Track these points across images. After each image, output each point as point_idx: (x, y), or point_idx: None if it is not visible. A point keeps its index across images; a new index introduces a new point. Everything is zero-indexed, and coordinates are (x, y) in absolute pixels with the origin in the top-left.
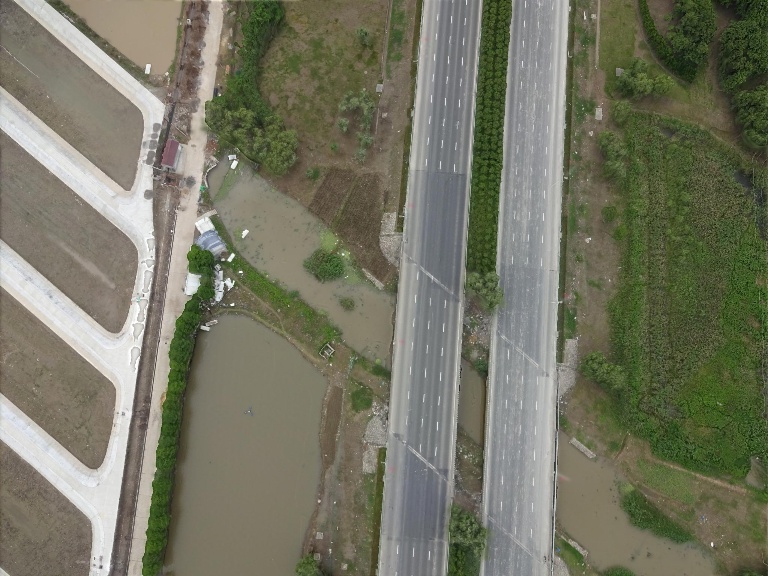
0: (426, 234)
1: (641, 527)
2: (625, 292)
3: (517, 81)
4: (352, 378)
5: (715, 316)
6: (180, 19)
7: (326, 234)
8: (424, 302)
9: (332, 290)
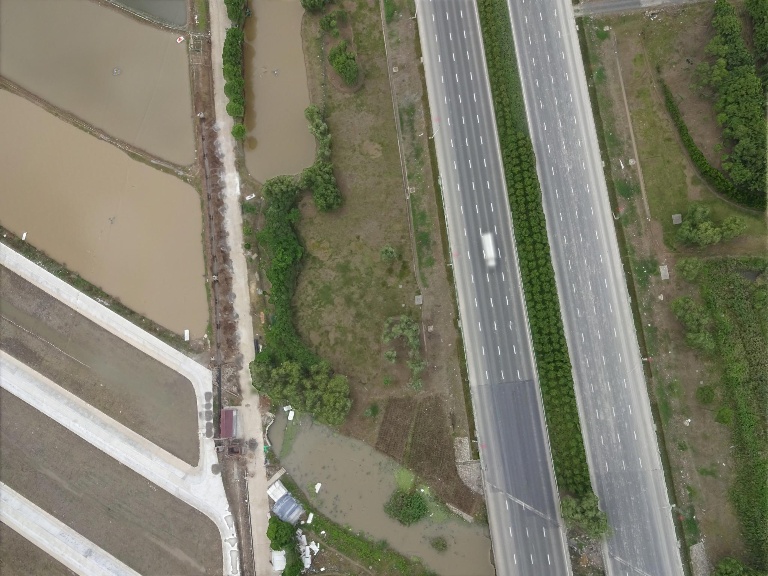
0: (505, 456)
1: None
2: (745, 476)
3: (564, 260)
4: None
5: None
6: (206, 276)
7: (400, 471)
8: (521, 534)
9: (420, 532)
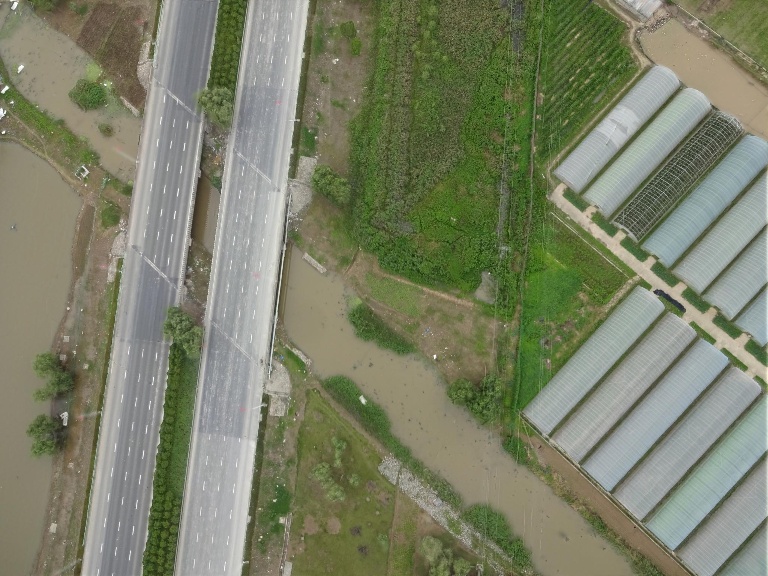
0: (175, 59)
1: (363, 337)
2: (368, 111)
3: None
4: (103, 197)
5: (456, 132)
6: None
7: (91, 66)
8: (168, 123)
9: (93, 118)
